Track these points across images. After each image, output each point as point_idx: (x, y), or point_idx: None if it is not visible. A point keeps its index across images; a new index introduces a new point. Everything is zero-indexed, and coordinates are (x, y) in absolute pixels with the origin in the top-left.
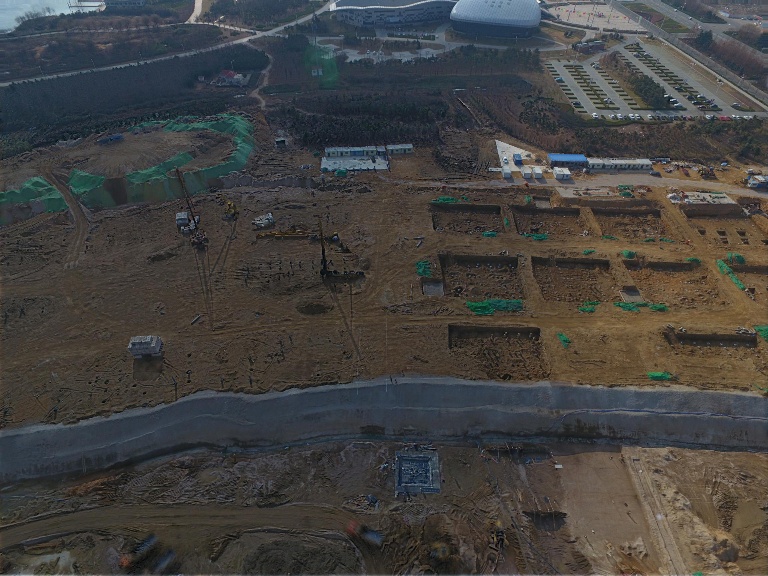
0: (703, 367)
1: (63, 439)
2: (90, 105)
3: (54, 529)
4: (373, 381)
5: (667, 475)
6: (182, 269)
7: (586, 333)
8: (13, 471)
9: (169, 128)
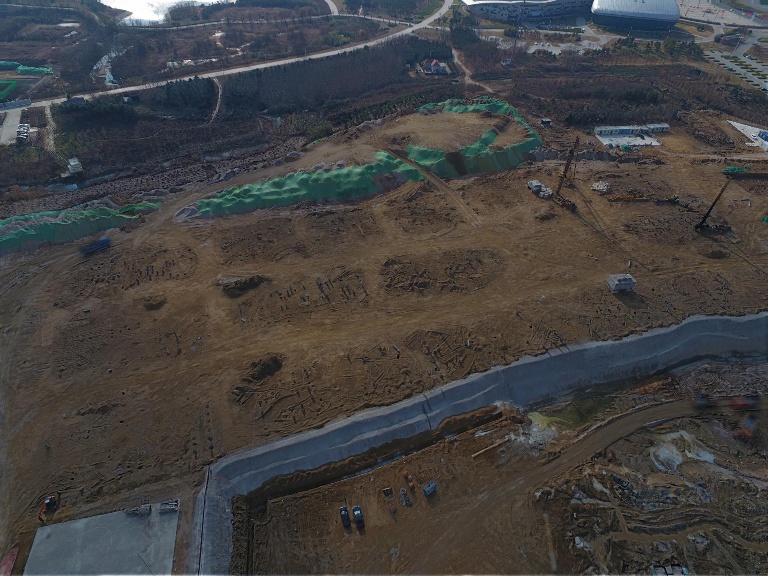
0: None
1: (617, 352)
2: (330, 90)
3: (658, 416)
4: None
5: None
6: (574, 226)
7: None
8: (589, 377)
9: (450, 110)
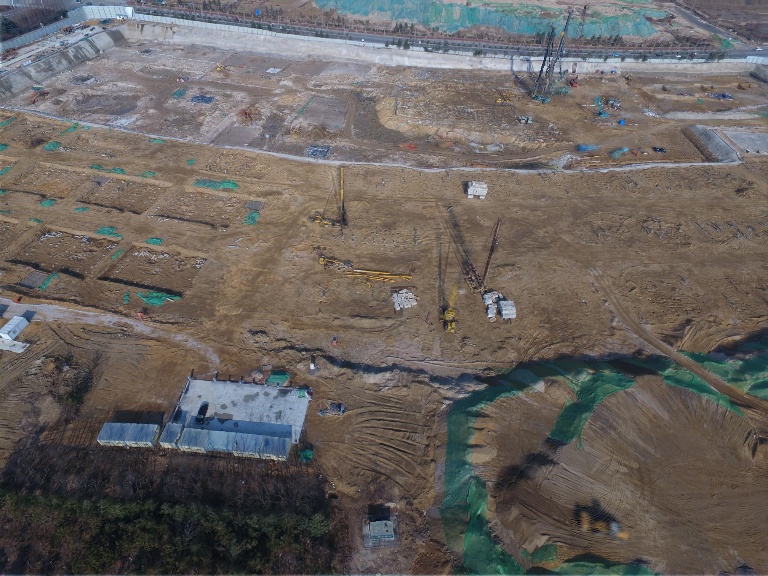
0: (125, 140)
1: None
2: None
3: (488, 157)
4: (328, 162)
5: (199, 133)
6: None
7: (171, 163)
8: None
9: None
